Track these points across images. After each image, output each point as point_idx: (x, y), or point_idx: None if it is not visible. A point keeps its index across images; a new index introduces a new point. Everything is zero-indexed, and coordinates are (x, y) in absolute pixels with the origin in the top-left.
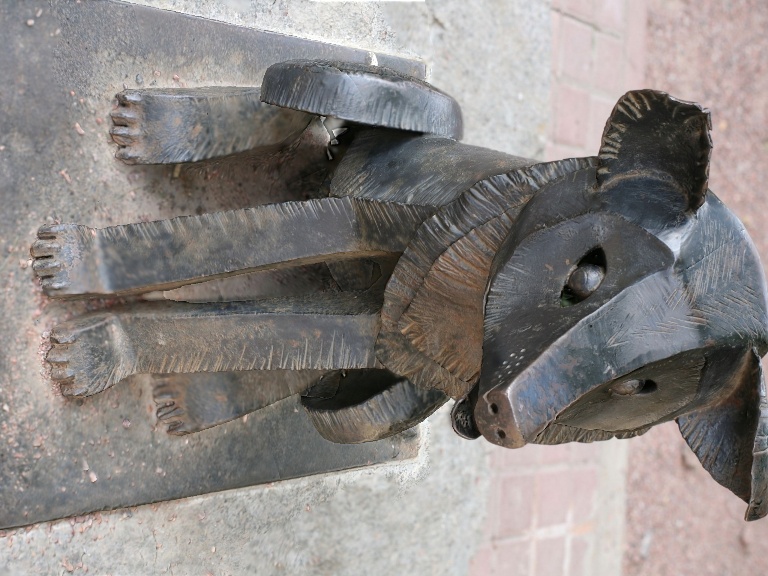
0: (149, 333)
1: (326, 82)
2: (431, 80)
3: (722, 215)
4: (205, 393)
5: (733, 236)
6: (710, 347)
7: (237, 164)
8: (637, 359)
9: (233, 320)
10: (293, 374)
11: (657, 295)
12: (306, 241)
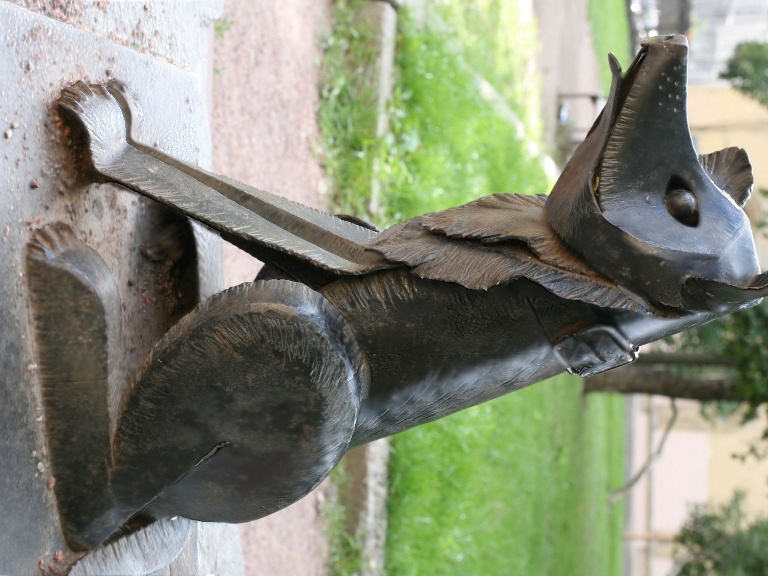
0: (146, 162)
1: None
2: None
3: None
4: (90, 262)
5: None
6: None
7: (150, 329)
8: None
9: (229, 201)
10: (115, 382)
11: None
12: (325, 224)
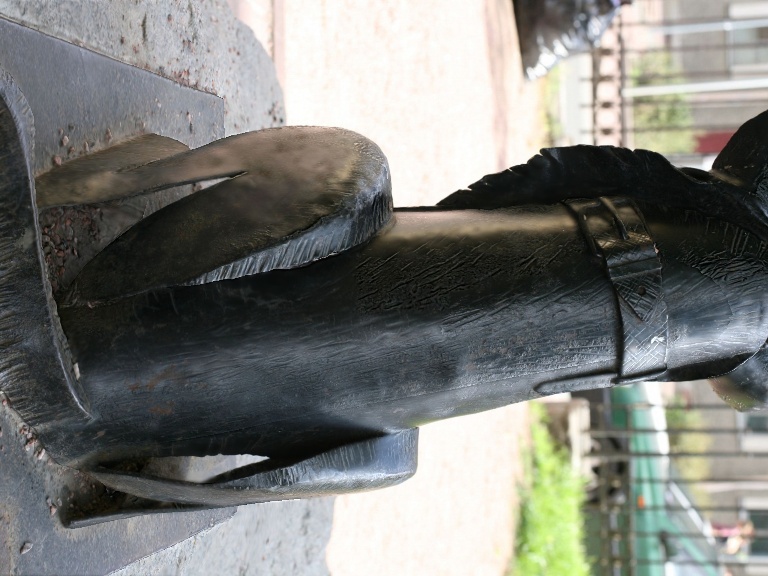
0: None
1: None
2: None
3: None
4: None
5: None
6: None
7: None
8: None
9: None
10: None
11: None
12: None
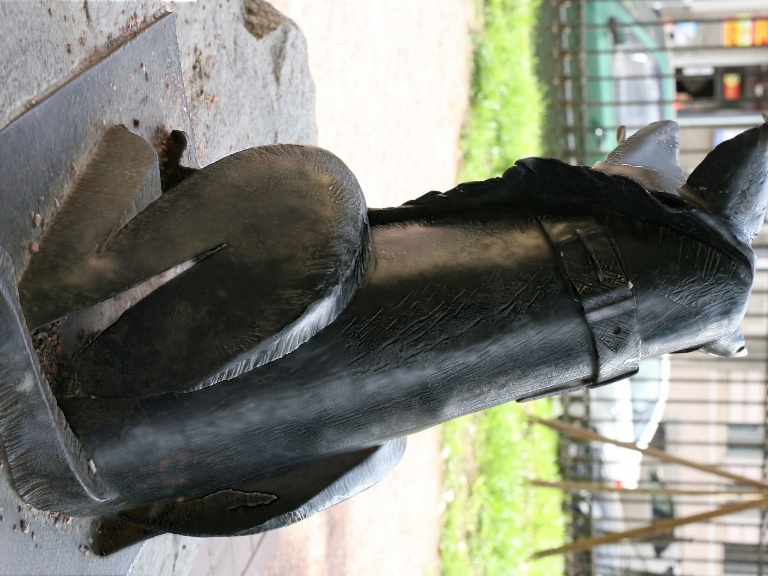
0: None
1: None
2: None
3: None
4: None
5: None
6: None
7: None
8: None
9: None
10: None
11: None
12: None
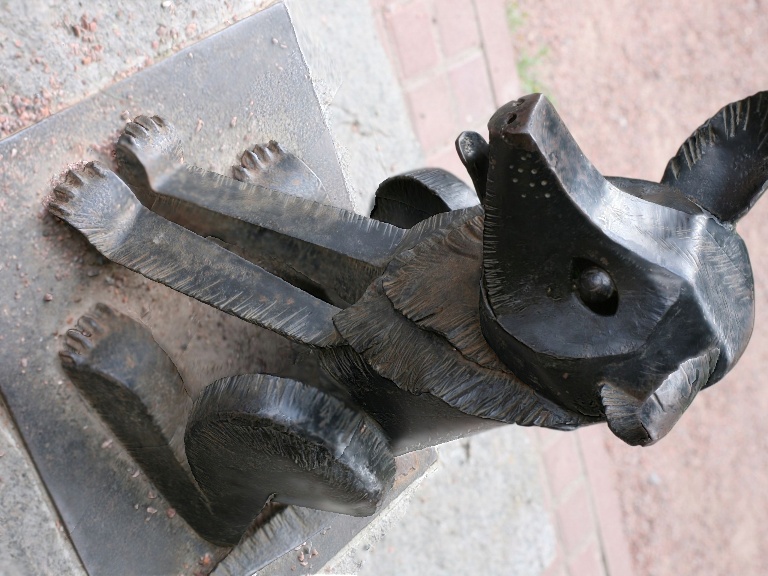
0: (154, 229)
1: (448, 177)
2: (431, 475)
3: (746, 259)
4: (123, 347)
5: (746, 278)
6: (690, 286)
7: None
8: (628, 241)
9: (231, 257)
10: None
11: (673, 223)
12: (344, 240)
